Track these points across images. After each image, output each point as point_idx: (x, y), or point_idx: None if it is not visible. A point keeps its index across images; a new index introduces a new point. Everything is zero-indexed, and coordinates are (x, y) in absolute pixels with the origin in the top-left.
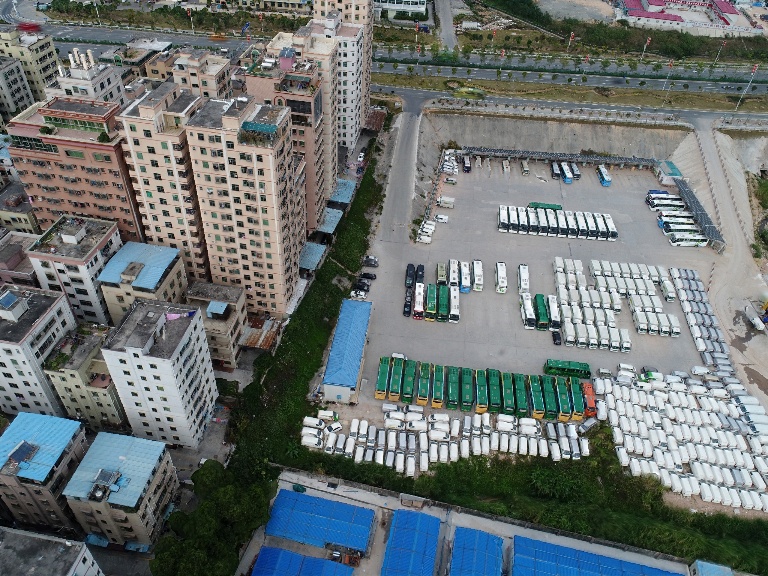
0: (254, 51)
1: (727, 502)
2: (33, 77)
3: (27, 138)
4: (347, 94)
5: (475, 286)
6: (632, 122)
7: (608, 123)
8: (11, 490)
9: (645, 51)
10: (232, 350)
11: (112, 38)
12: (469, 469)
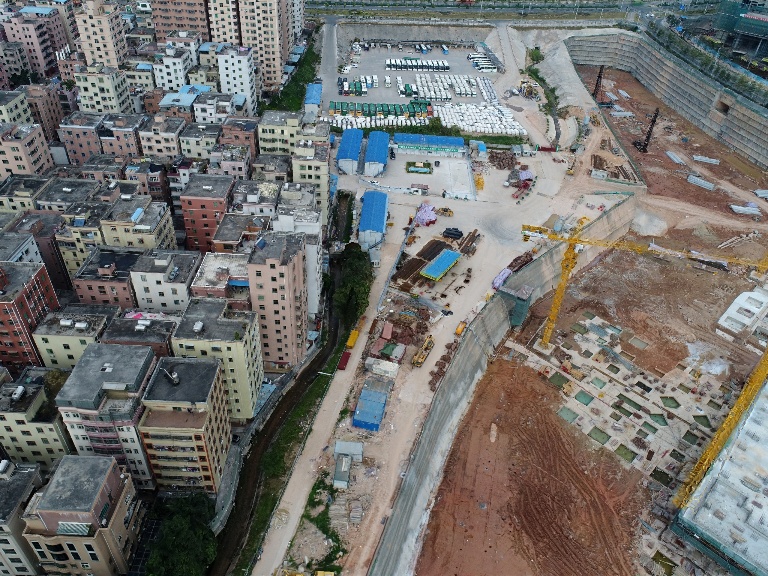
0: None
1: (487, 131)
2: None
3: None
4: (294, 1)
5: (374, 84)
6: (460, 24)
7: (447, 25)
8: None
9: None
10: (260, 90)
11: None
12: (375, 130)
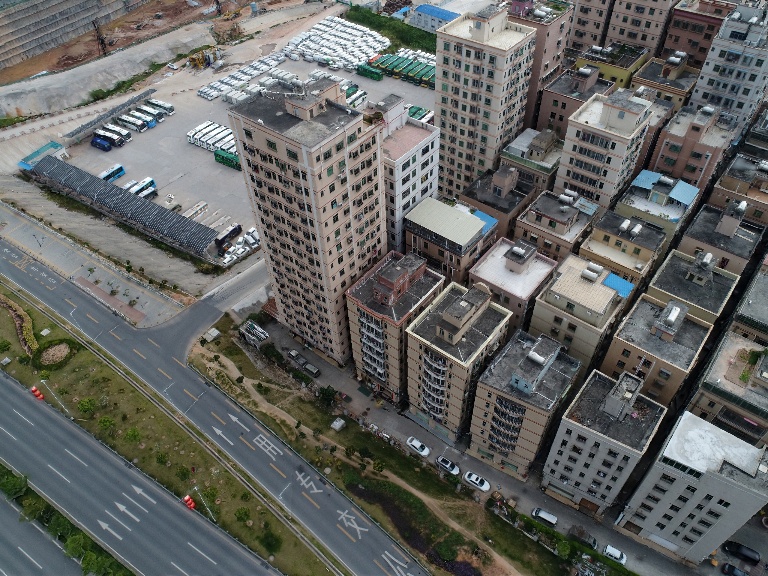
0: (485, 288)
1: None
2: None
3: None
4: None
5: None
6: None
7: None
8: None
9: None
10: None
11: None
12: None
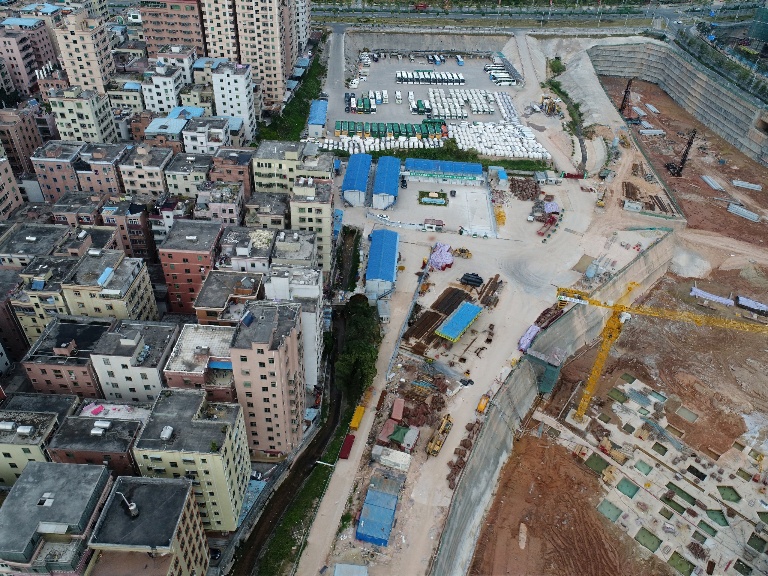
0: None
1: (507, 154)
2: (95, 13)
3: (149, 2)
4: (299, 9)
5: (384, 100)
6: (476, 33)
7: (461, 34)
8: None
9: (490, 3)
10: (260, 109)
11: (123, 4)
12: (385, 153)
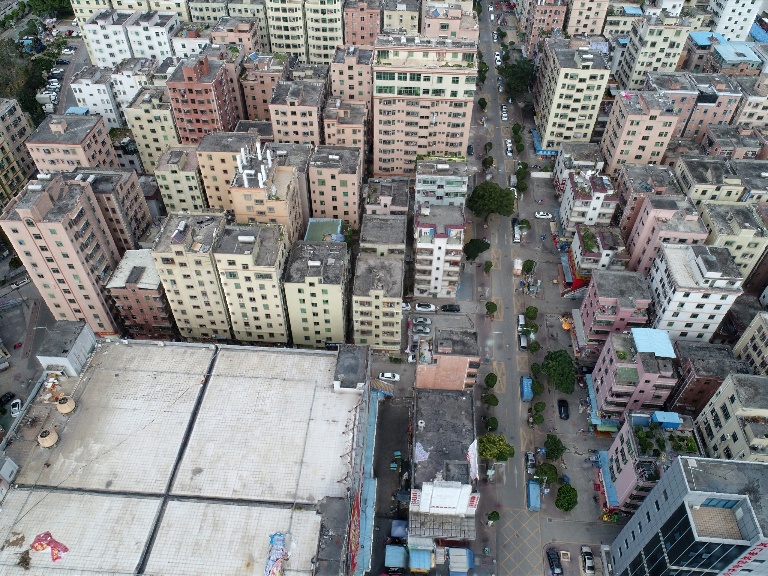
0: None
1: None
2: None
3: None
4: None
5: None
6: None
7: None
8: (702, 61)
9: None
10: None
11: None
12: None
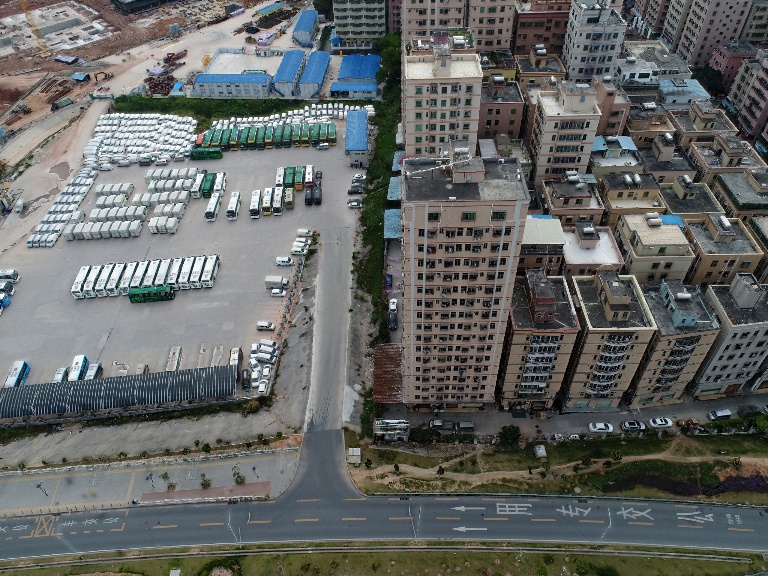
0: (610, 266)
1: None
2: None
3: None
4: None
5: None
6: None
7: None
8: None
9: None
10: None
11: None
12: None
